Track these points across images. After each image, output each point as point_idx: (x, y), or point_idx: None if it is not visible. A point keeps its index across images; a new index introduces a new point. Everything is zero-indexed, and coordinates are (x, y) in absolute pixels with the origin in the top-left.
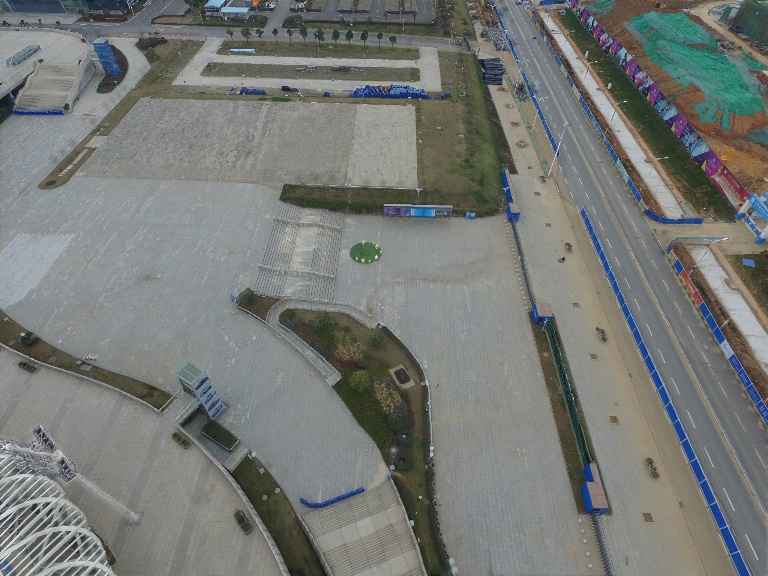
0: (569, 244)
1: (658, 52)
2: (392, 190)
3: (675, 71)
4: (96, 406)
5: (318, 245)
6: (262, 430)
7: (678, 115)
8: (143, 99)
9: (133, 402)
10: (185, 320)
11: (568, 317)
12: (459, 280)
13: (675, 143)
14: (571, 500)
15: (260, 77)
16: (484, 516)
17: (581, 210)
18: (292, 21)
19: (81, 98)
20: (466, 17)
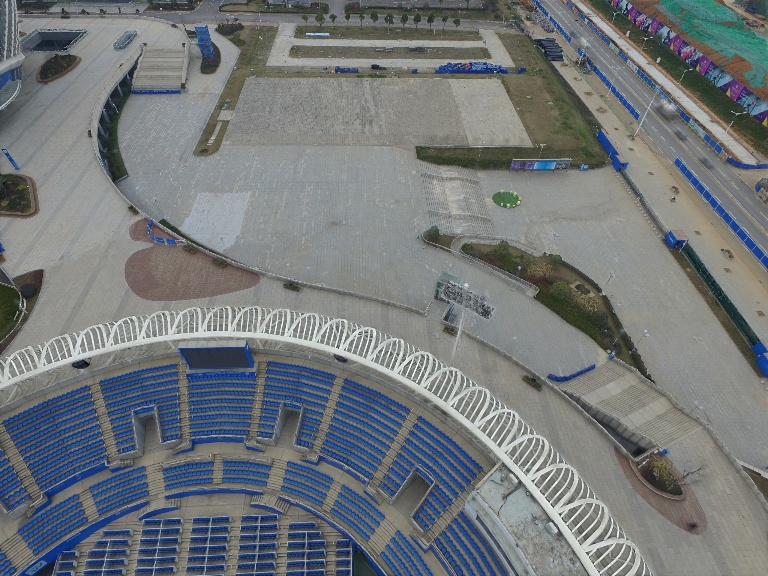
0: (675, 187)
1: (696, 30)
2: (511, 148)
3: (716, 45)
4: (367, 312)
5: (466, 194)
6: (492, 331)
7: (733, 81)
8: (250, 78)
9: (396, 308)
10: (385, 254)
11: (695, 242)
12: (595, 218)
13: (733, 105)
14: (750, 369)
15: (346, 58)
16: (688, 383)
17: None
18: (353, 7)
19: (189, 79)
20: (506, 3)
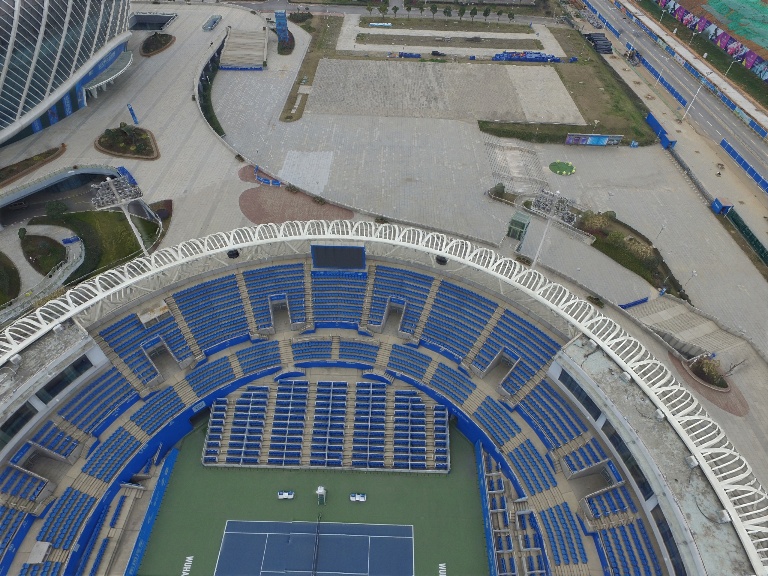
0: (721, 164)
1: (744, 28)
2: (566, 125)
3: (763, 42)
4: None
5: (525, 162)
6: None
7: None
8: (323, 59)
9: (473, 241)
10: (456, 206)
11: (739, 210)
12: (644, 187)
13: None
14: None
15: (408, 45)
16: (731, 320)
17: (720, 142)
18: (412, 1)
19: (269, 58)
20: (556, 1)
